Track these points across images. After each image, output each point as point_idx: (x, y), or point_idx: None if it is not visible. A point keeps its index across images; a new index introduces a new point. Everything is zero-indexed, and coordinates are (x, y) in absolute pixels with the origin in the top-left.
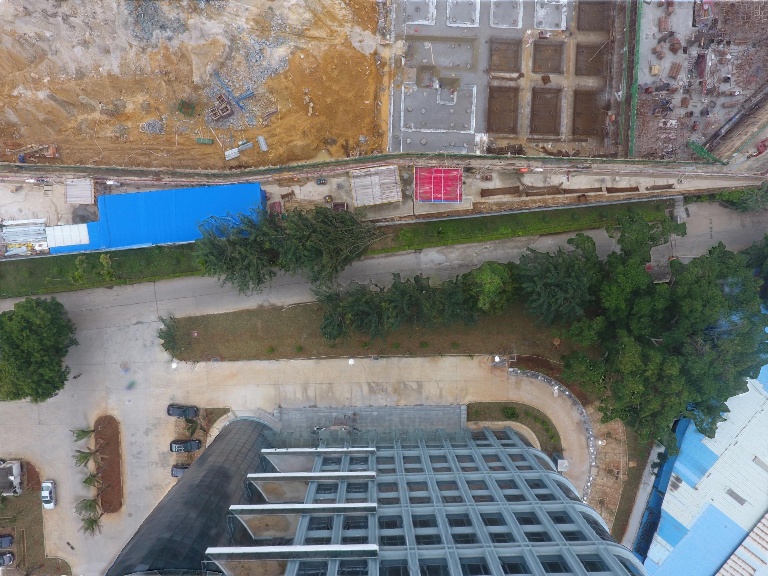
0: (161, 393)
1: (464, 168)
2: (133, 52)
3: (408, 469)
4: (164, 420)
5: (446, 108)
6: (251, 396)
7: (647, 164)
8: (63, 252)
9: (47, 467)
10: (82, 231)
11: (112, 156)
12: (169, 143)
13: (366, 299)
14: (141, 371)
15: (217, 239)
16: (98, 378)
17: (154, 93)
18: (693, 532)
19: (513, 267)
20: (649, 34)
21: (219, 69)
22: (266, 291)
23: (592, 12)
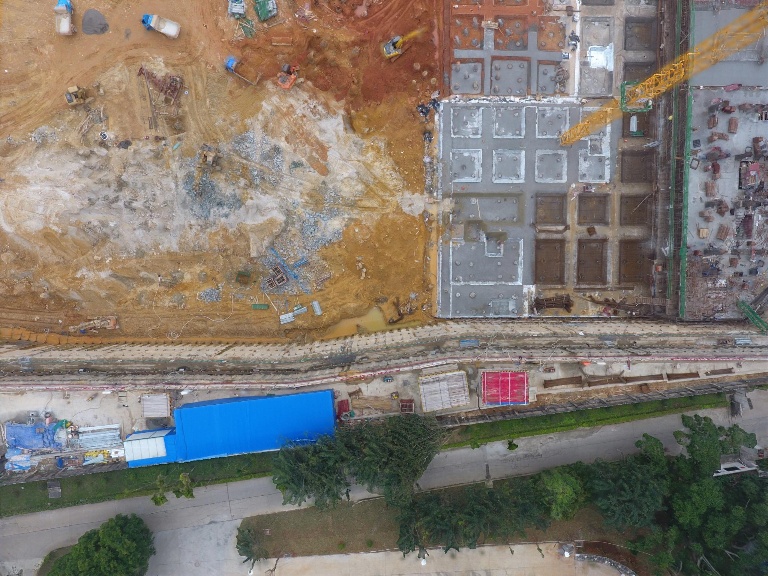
0: None
1: None
2: (192, 232)
3: None
4: None
5: (493, 261)
6: None
7: (702, 336)
8: (141, 465)
9: None
10: (159, 444)
11: (170, 323)
12: (225, 309)
13: (442, 515)
14: (215, 569)
15: (297, 465)
16: None
17: (211, 264)
18: None
19: (583, 472)
20: (696, 198)
21: (274, 240)
22: None
23: (634, 163)
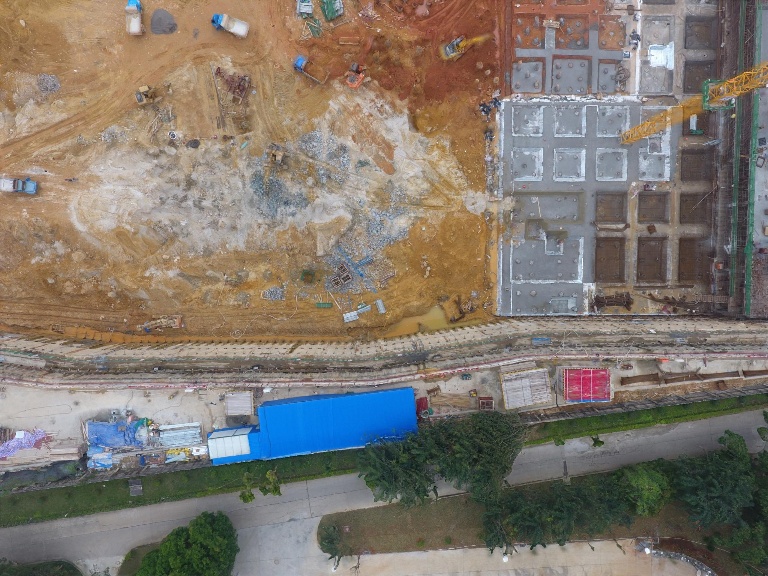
0: None
1: None
2: (261, 231)
3: None
4: None
5: (554, 259)
6: None
7: None
8: (225, 463)
9: None
10: (243, 442)
11: (234, 322)
12: (289, 308)
13: (530, 512)
14: (294, 566)
15: (387, 462)
16: (253, 575)
17: (276, 262)
18: None
19: (667, 469)
20: (761, 196)
21: (339, 238)
22: None
23: (694, 161)
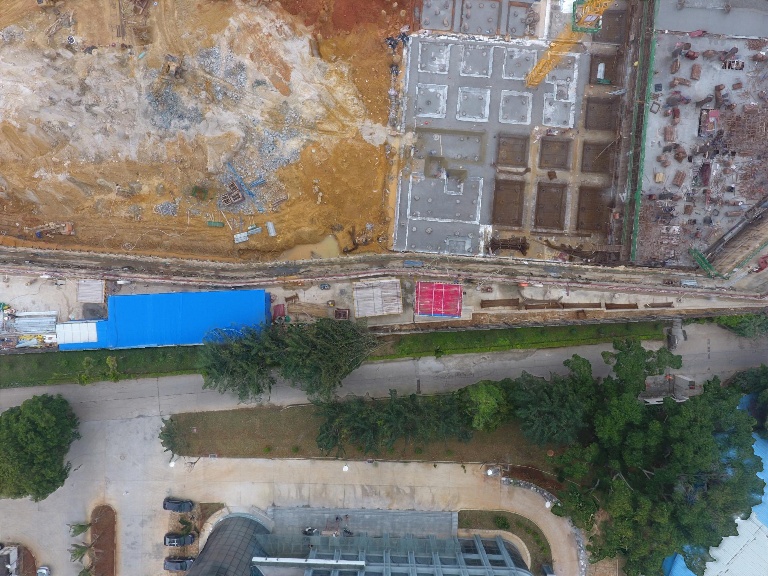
0: (158, 486)
1: (465, 279)
2: (151, 141)
3: None
4: (159, 512)
5: (452, 198)
6: (246, 493)
7: (648, 275)
8: (71, 349)
9: (43, 553)
10: (91, 330)
11: (125, 234)
12: (181, 224)
13: (362, 415)
14: (140, 463)
15: (220, 352)
16: (98, 468)
17: (169, 177)
18: None
19: (509, 386)
20: (655, 142)
21: (233, 157)
22: (266, 391)
23: (600, 111)
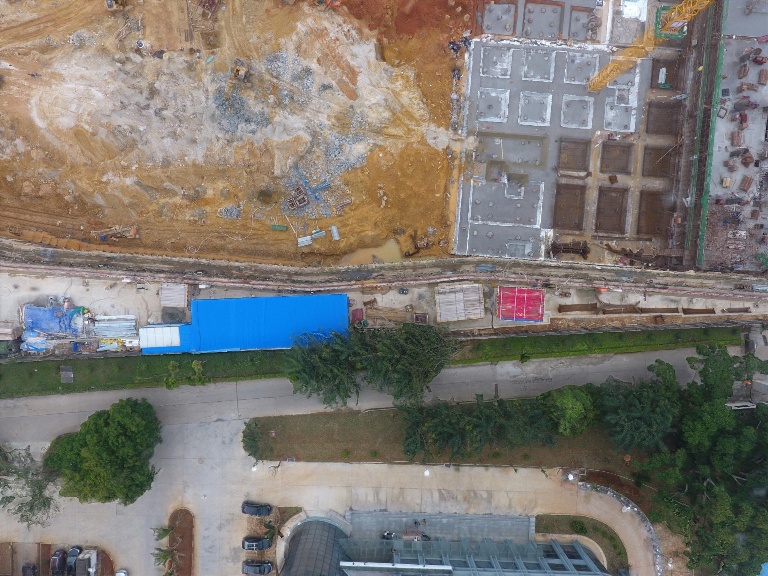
0: (236, 490)
1: (543, 283)
2: (219, 145)
3: None
4: (237, 516)
5: (513, 202)
6: (323, 497)
7: (719, 279)
8: (154, 353)
9: (121, 556)
10: (174, 334)
11: (189, 238)
12: (244, 228)
13: (450, 420)
14: (218, 467)
15: (309, 356)
16: (176, 472)
17: (234, 181)
18: None
19: (593, 391)
20: (722, 147)
21: (298, 161)
22: None
23: (661, 115)
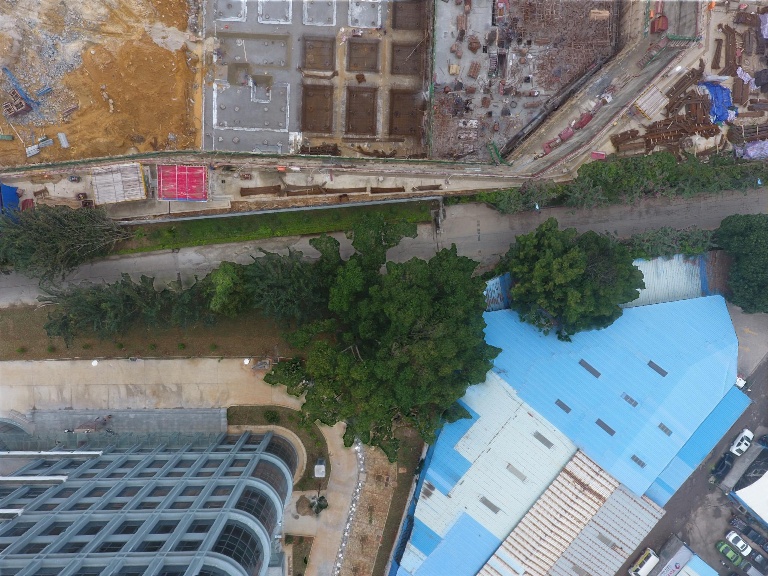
0: None
1: (223, 166)
2: None
3: (115, 474)
4: None
5: (260, 106)
6: (4, 397)
7: (431, 164)
8: None
9: None
10: None
11: None
12: None
13: None
14: None
15: None
16: None
17: None
18: (447, 541)
19: None
20: (447, 33)
21: (15, 64)
22: (18, 290)
23: (409, 10)
